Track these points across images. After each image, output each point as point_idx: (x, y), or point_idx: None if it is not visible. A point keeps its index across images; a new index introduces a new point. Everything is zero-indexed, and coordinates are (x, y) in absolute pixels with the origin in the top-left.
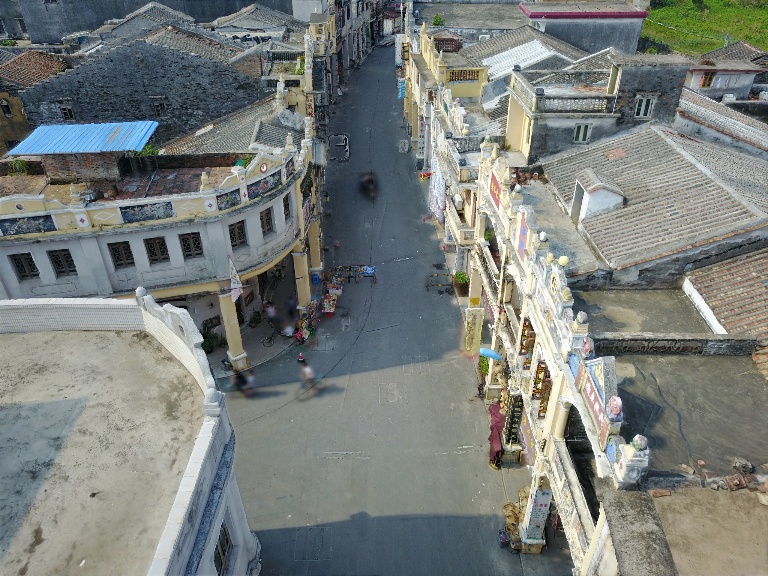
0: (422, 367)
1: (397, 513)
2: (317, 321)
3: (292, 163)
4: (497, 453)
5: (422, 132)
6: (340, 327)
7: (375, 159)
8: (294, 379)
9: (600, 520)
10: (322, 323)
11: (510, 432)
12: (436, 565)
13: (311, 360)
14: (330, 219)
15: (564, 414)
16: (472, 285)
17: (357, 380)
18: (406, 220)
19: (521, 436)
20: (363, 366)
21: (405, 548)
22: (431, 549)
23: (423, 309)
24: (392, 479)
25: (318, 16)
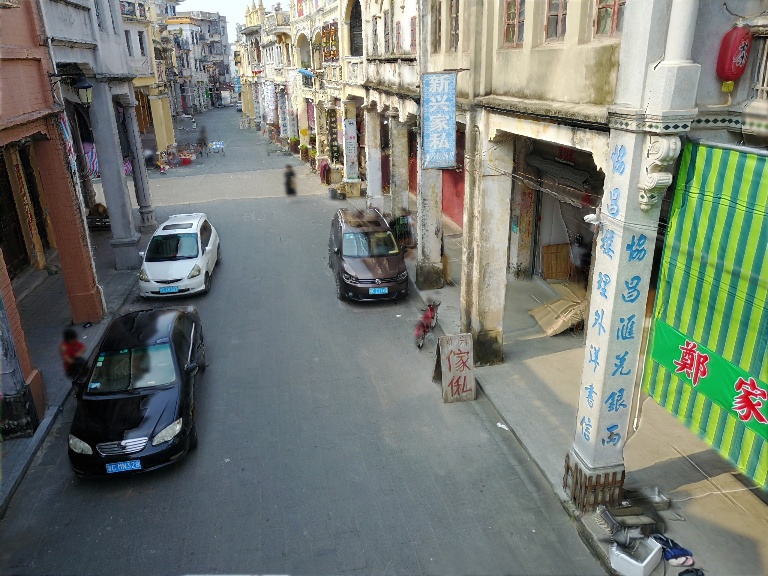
0: (266, 170)
1: (250, 197)
2: (175, 166)
3: (144, 10)
4: (325, 166)
5: (257, 98)
6: (196, 166)
7: (220, 131)
8: (158, 178)
9: (362, 13)
10: (180, 166)
11: (332, 150)
12: (282, 204)
13: (172, 173)
14: (182, 146)
15: (347, 31)
16: (299, 117)
17: (212, 175)
18: (249, 142)
19: (341, 156)
20: (217, 172)
21: (257, 203)
22: (278, 202)
23: (266, 159)
24: (245, 191)
25: (159, 14)
